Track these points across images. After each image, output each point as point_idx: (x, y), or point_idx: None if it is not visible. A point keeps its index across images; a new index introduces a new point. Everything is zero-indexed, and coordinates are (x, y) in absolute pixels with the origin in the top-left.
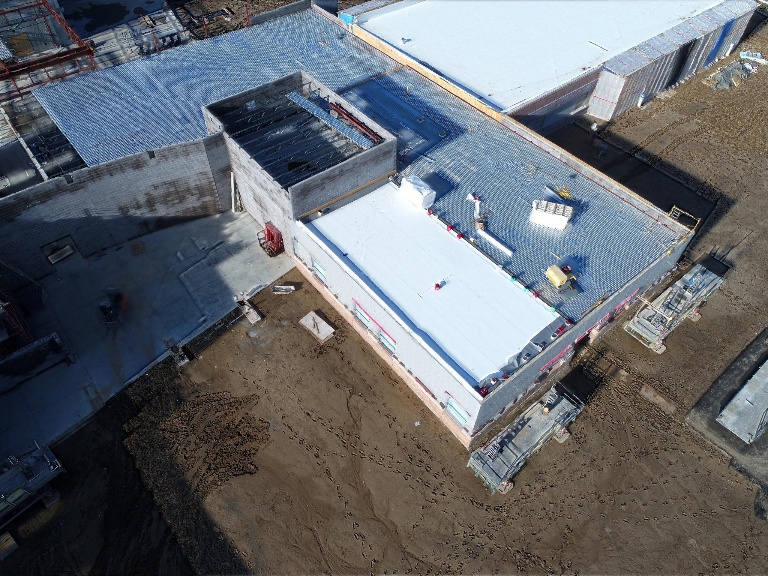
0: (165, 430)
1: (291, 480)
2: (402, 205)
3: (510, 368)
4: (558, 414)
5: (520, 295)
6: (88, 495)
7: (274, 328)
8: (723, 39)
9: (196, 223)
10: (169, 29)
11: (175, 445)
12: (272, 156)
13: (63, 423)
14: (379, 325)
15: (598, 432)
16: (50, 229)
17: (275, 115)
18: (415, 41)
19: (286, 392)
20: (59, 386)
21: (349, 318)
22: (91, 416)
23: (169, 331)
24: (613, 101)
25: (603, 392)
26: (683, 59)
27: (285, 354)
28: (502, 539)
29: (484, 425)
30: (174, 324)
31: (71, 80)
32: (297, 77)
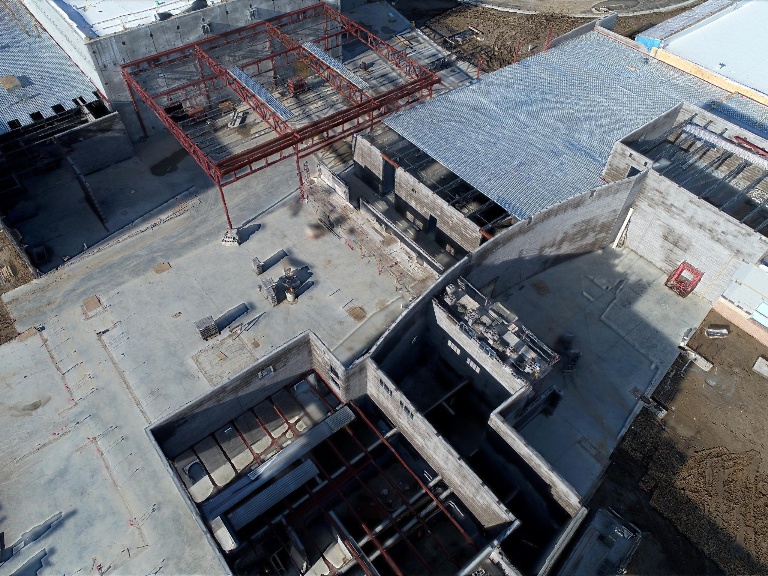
0: (685, 490)
1: None
2: None
3: None
4: None
5: None
6: (650, 563)
7: (730, 376)
8: None
9: (583, 260)
10: (429, 50)
11: (705, 507)
12: None
13: (581, 482)
14: None
15: None
16: (492, 271)
17: None
18: (730, 66)
19: None
20: (552, 441)
21: None
22: (602, 474)
23: (627, 379)
24: None
25: None
26: None
27: (759, 405)
28: None
29: None
30: (628, 371)
31: (413, 108)
32: (679, 108)
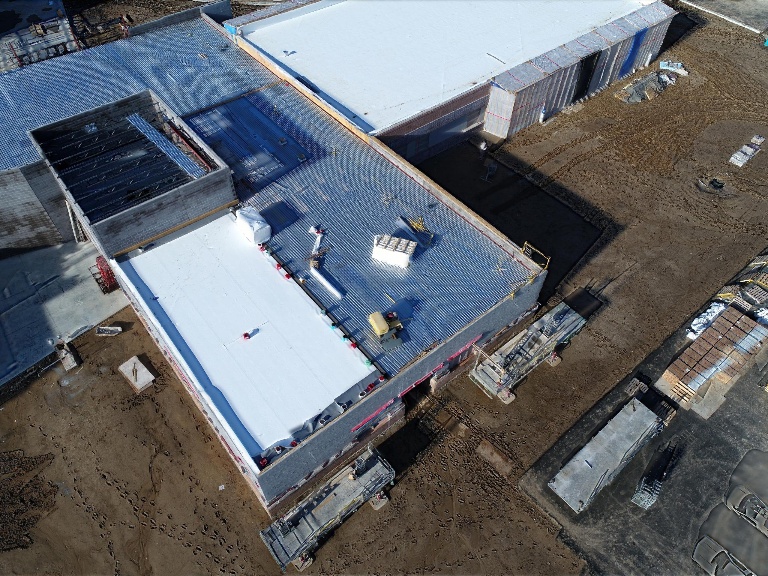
0: None
1: (67, 555)
2: (235, 240)
3: (302, 434)
4: (370, 479)
5: (338, 345)
6: None
7: (90, 375)
8: (638, 49)
9: (33, 255)
10: (59, 38)
11: None
12: (112, 183)
13: None
14: (185, 377)
15: (421, 497)
16: None
17: (125, 137)
18: (300, 53)
19: (85, 450)
20: None
21: (171, 365)
22: None
23: None
24: (507, 118)
25: (436, 449)
26: (589, 71)
27: (94, 406)
28: None
29: (284, 493)
30: None
31: None
32: (145, 97)
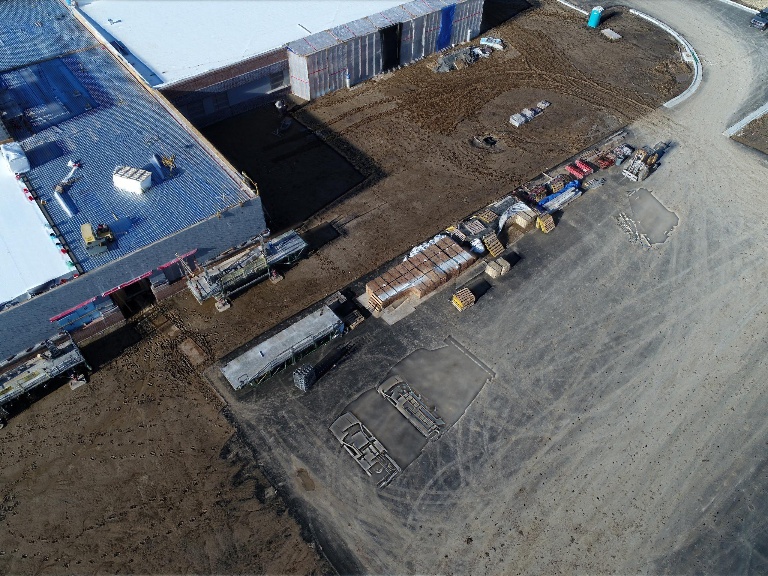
0: None
1: None
2: None
3: None
4: (63, 361)
5: (50, 251)
6: None
7: None
8: (451, 24)
9: None
10: None
11: None
12: None
13: None
14: None
15: (116, 380)
16: None
17: None
18: (124, 22)
19: None
20: None
21: None
22: None
23: None
24: (306, 81)
25: (144, 345)
26: (395, 42)
27: None
28: None
29: None
30: None
31: None
32: None
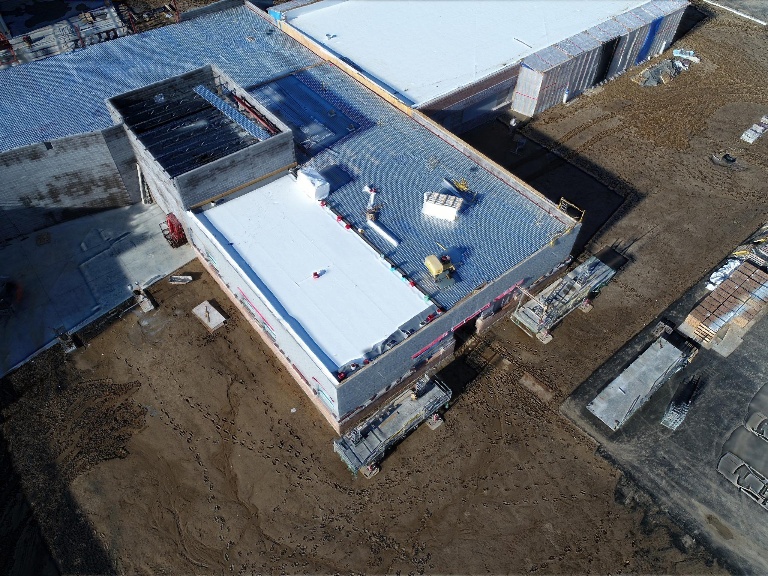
0: (43, 415)
1: (160, 464)
2: (297, 196)
3: (372, 354)
4: (428, 401)
5: (397, 284)
6: None
7: (166, 317)
8: (653, 37)
9: (105, 214)
10: (108, 25)
11: (50, 430)
12: None
13: None
14: (259, 313)
15: (472, 419)
16: None
17: None
18: (340, 37)
19: (168, 379)
20: None
21: (240, 307)
22: None
23: (61, 319)
24: (534, 97)
25: (483, 380)
26: (609, 56)
27: (173, 342)
28: (360, 522)
29: (353, 411)
30: (67, 312)
31: None
32: (207, 71)
